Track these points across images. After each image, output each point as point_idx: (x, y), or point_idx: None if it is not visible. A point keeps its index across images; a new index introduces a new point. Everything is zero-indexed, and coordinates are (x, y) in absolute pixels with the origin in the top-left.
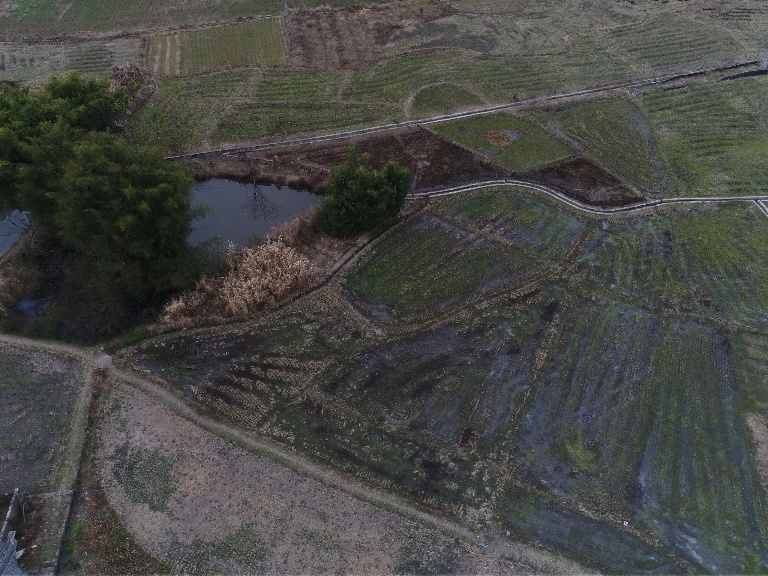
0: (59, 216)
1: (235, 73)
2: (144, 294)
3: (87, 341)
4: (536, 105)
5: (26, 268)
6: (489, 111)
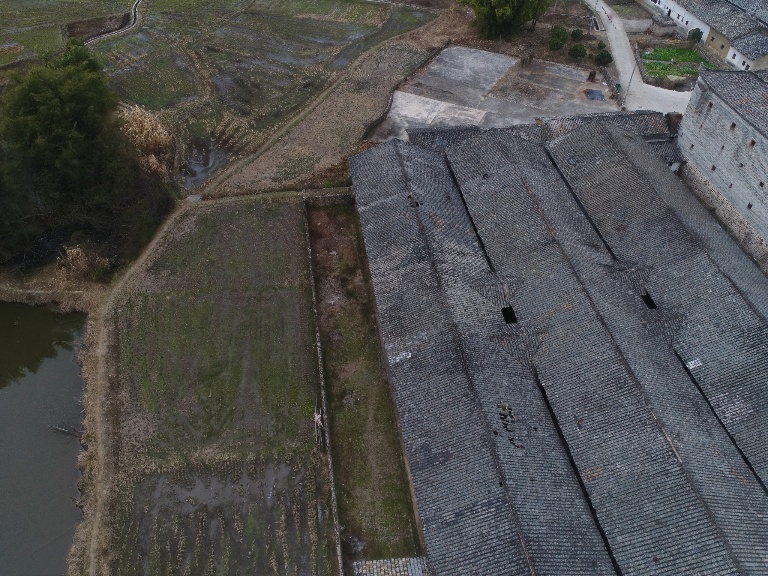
0: None
1: None
2: None
3: (167, 210)
4: None
5: (37, 275)
6: None
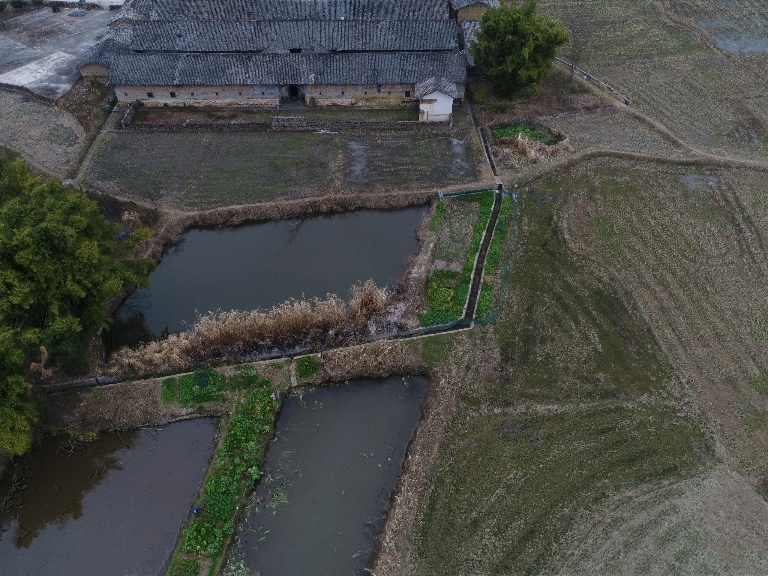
0: None
1: None
2: None
3: None
4: None
5: None
6: None
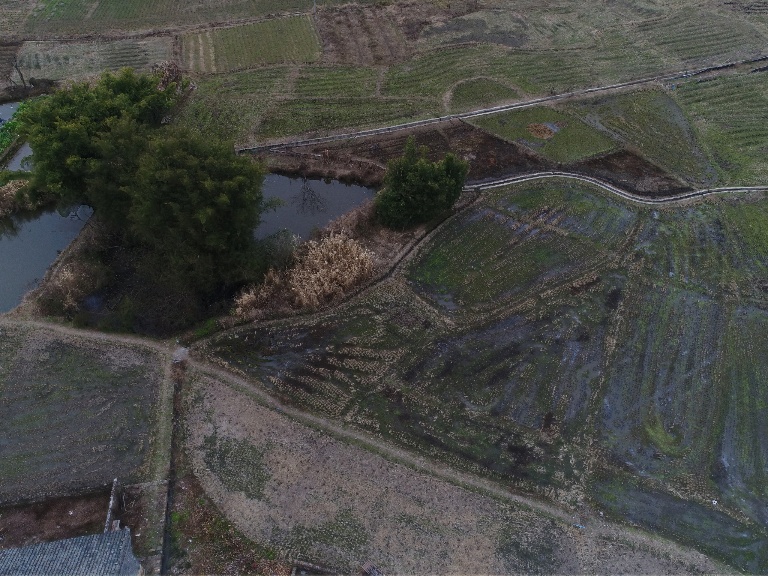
0: (135, 210)
1: (271, 70)
2: (214, 287)
3: (161, 334)
4: (573, 98)
5: (89, 264)
6: (528, 105)
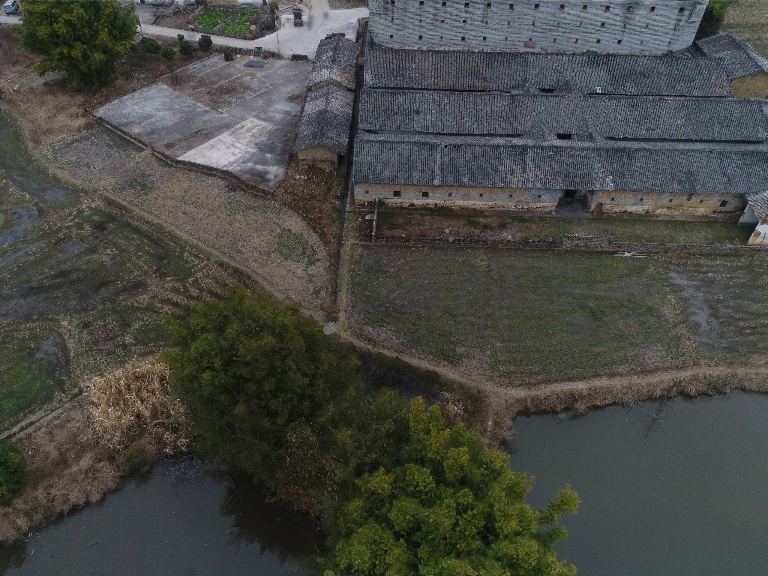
0: None
1: None
2: None
3: None
4: None
5: None
6: None
